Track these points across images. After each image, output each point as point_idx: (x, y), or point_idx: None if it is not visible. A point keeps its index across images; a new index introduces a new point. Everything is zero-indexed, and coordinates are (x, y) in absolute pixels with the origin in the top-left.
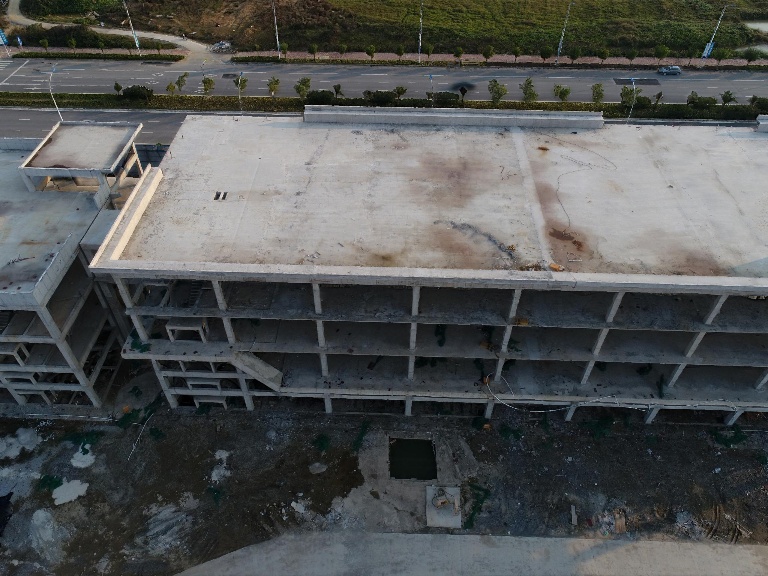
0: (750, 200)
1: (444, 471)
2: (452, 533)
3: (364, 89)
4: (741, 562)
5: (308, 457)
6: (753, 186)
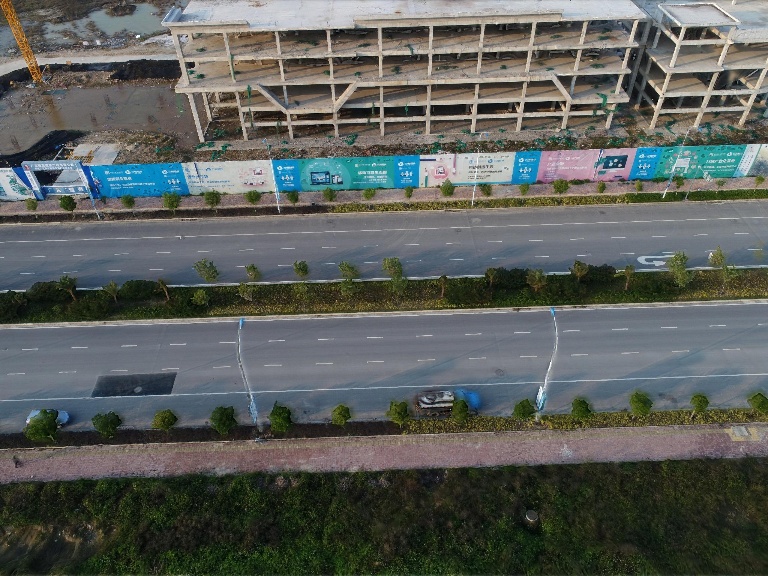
0: None
1: None
2: None
3: (603, 332)
4: None
5: None
6: (285, 4)
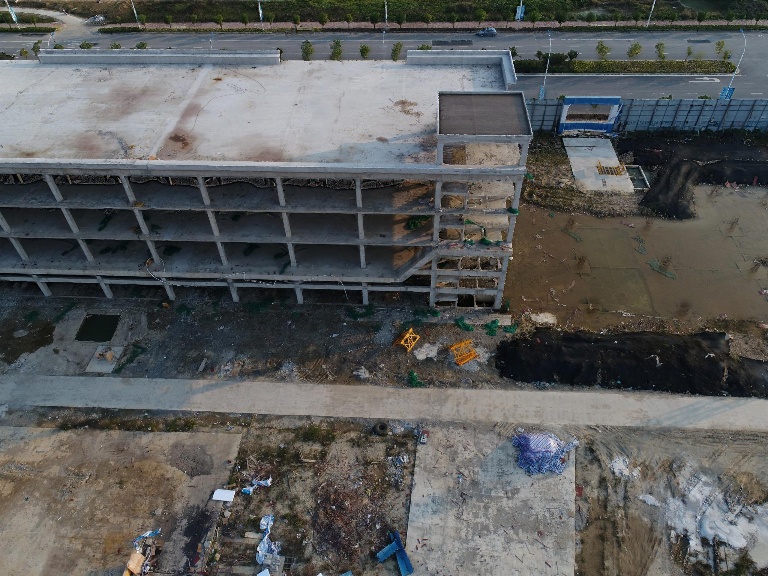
0: (351, 113)
1: (118, 336)
2: (102, 376)
3: None
4: (315, 395)
5: (17, 326)
6: (364, 103)
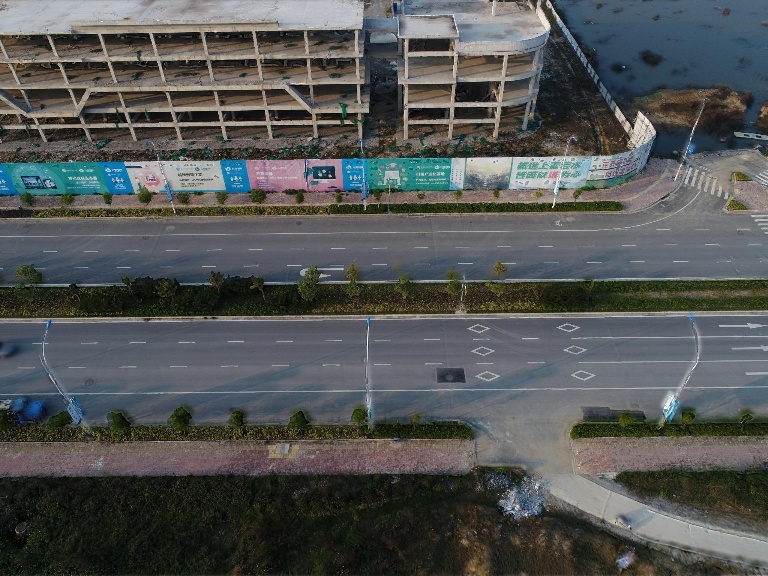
0: (41, 4)
1: None
2: None
3: (217, 344)
4: None
5: None
6: (28, 8)
